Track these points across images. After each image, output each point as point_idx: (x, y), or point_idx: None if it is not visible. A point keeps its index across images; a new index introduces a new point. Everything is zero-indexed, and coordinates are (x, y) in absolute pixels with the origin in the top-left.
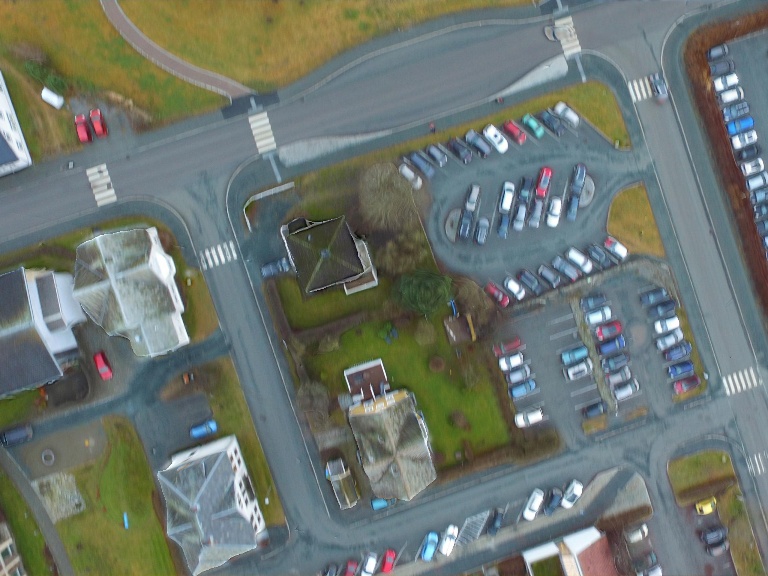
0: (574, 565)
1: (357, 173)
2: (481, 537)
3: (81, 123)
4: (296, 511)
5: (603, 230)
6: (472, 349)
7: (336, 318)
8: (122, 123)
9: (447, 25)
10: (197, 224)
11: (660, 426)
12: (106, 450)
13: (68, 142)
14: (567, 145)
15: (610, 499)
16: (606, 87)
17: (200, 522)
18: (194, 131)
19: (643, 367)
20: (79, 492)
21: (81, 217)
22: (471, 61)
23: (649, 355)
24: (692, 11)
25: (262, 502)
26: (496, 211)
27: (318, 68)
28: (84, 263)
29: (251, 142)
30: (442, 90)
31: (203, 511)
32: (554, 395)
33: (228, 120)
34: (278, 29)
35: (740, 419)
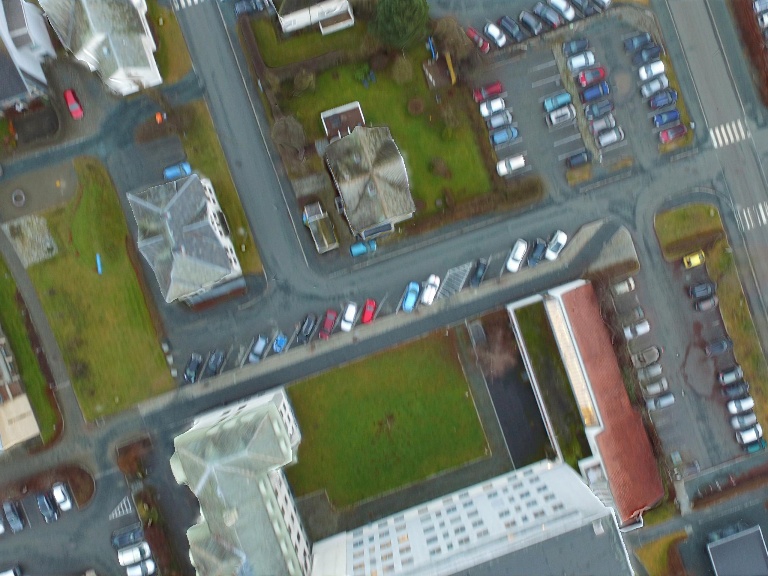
0: (558, 310)
1: None
2: (464, 290)
3: None
4: (273, 259)
5: None
6: (452, 94)
7: (312, 58)
8: None
9: None
10: None
11: (646, 178)
12: (78, 192)
13: None
14: None
15: (595, 252)
16: None
17: (171, 229)
18: None
19: (628, 116)
20: (51, 236)
21: None
22: None
23: (634, 104)
24: None
25: (238, 248)
26: None
27: None
28: None
29: None
30: None
31: (174, 221)
32: (537, 144)
33: None
34: None
35: (728, 172)
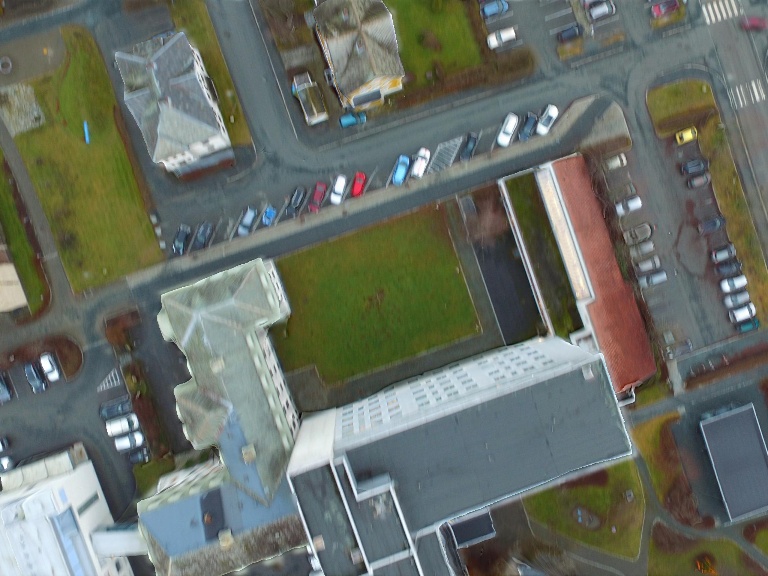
0: (549, 181)
1: None
2: (454, 165)
3: None
4: (262, 132)
5: None
6: None
7: None
8: None
9: None
10: None
11: (638, 54)
12: (65, 60)
13: None
14: None
15: (587, 128)
16: None
17: (157, 80)
18: None
19: None
20: (38, 105)
21: None
22: None
23: None
24: None
25: (227, 119)
26: None
27: None
28: None
29: None
30: None
31: (160, 72)
32: (528, 18)
33: None
34: None
35: (721, 49)
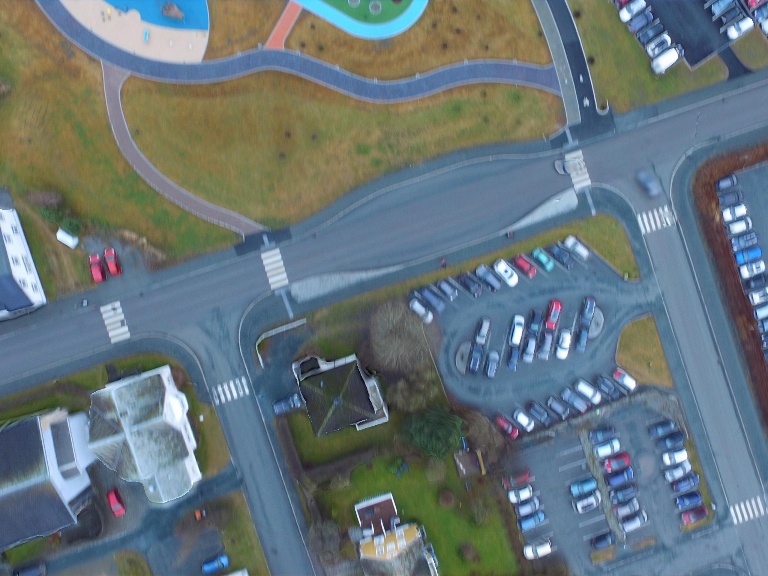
0: None
1: (368, 308)
2: None
3: (95, 263)
4: None
5: (612, 361)
6: (482, 482)
7: (347, 453)
8: (136, 261)
9: (458, 160)
10: (210, 360)
11: (668, 556)
12: None
13: (82, 280)
14: (576, 277)
15: None
16: (615, 220)
17: None
18: (207, 268)
19: (651, 498)
20: None
21: (95, 354)
22: (482, 196)
23: (657, 486)
24: (701, 143)
25: None
26: (506, 344)
27: (330, 205)
28: (99, 410)
29: (263, 278)
30: (453, 225)
31: None
32: (563, 526)
33: (241, 257)
34: (291, 164)
35: (747, 548)
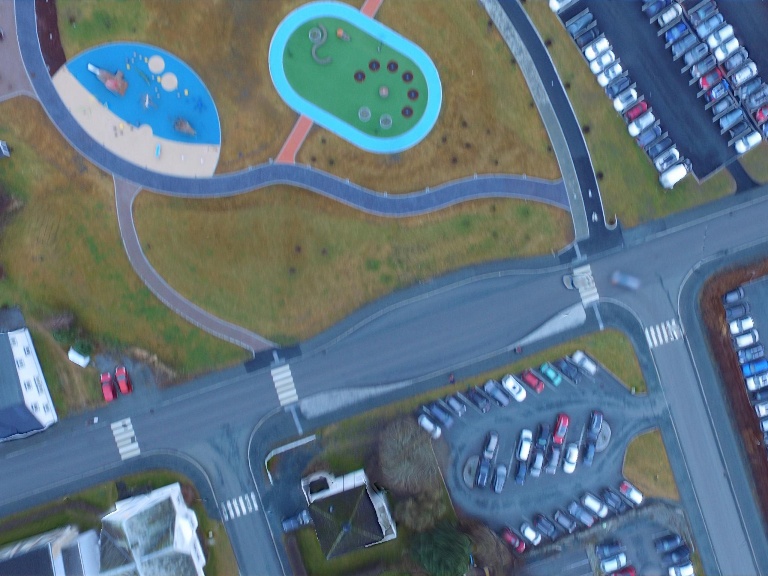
0: None
1: (377, 423)
2: None
3: (107, 382)
4: None
5: (619, 473)
6: None
7: (355, 569)
8: (147, 378)
9: (467, 276)
10: (219, 476)
11: None
12: None
13: (93, 398)
14: (584, 391)
15: None
16: (623, 334)
17: None
18: (217, 385)
19: None
20: None
21: (105, 471)
22: (490, 311)
23: None
24: (709, 257)
25: None
26: (513, 458)
27: (340, 321)
28: (109, 536)
29: (273, 395)
30: (462, 340)
31: None
32: None
33: (251, 373)
34: (301, 280)
35: None
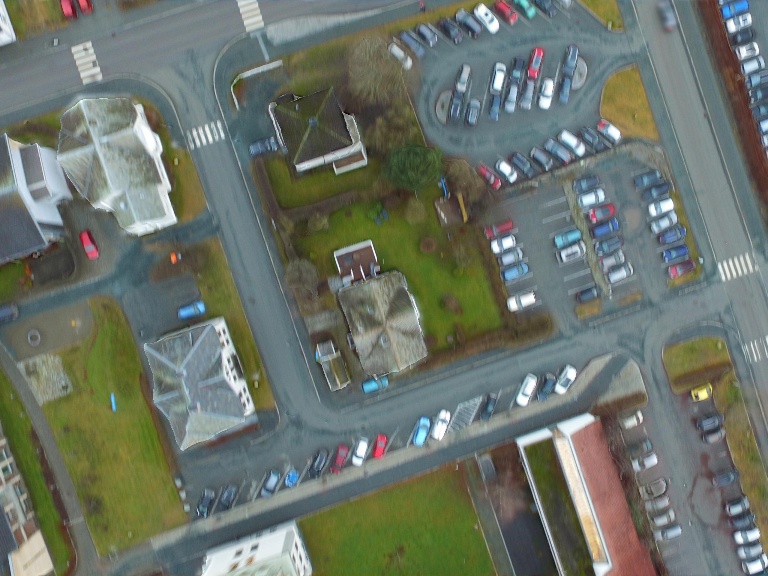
0: (568, 448)
1: (346, 52)
2: (474, 423)
3: None
4: (286, 395)
5: (596, 113)
6: (463, 231)
7: (325, 198)
8: None
9: None
10: (184, 103)
11: (655, 312)
12: (93, 331)
13: (53, 18)
14: (559, 27)
15: (604, 385)
16: None
17: (187, 387)
18: (180, 8)
19: (637, 251)
20: (66, 374)
21: (66, 95)
22: None
23: (643, 239)
24: None
25: (251, 385)
26: (487, 93)
27: None
28: (68, 132)
29: (238, 20)
30: None
31: (190, 378)
32: (547, 279)
33: None
34: None
35: (736, 305)
